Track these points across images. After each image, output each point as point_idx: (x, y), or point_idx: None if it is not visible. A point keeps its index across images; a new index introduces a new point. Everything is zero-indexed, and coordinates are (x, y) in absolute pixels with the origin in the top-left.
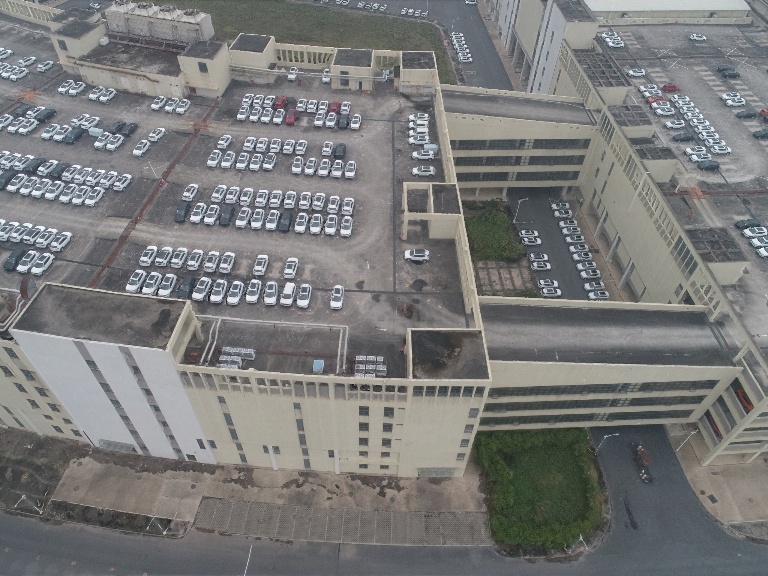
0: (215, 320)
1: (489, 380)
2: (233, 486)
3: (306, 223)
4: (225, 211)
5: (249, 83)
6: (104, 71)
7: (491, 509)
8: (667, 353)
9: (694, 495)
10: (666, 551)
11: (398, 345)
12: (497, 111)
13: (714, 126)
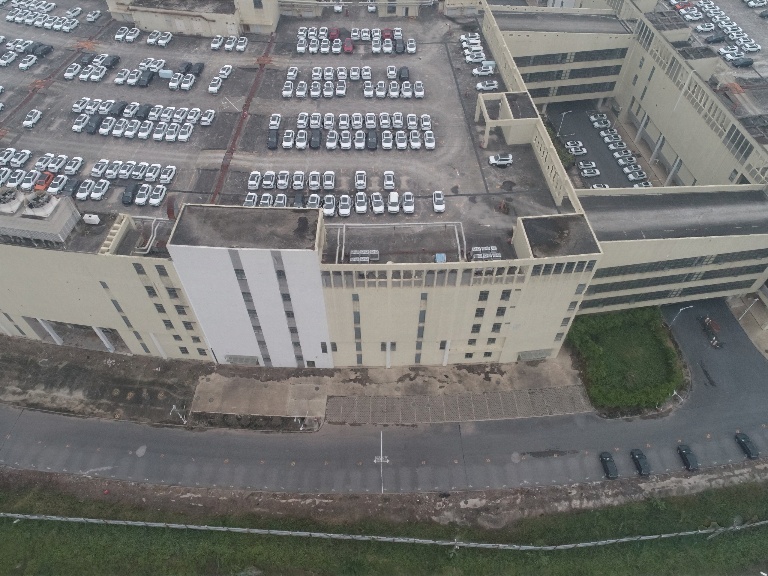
0: (339, 227)
1: (601, 253)
2: (353, 385)
3: (392, 140)
4: (314, 135)
5: (298, 17)
6: (158, 15)
7: (587, 381)
8: (737, 226)
9: (760, 354)
10: (743, 401)
11: (503, 237)
12: (539, 27)
13: (741, 27)
